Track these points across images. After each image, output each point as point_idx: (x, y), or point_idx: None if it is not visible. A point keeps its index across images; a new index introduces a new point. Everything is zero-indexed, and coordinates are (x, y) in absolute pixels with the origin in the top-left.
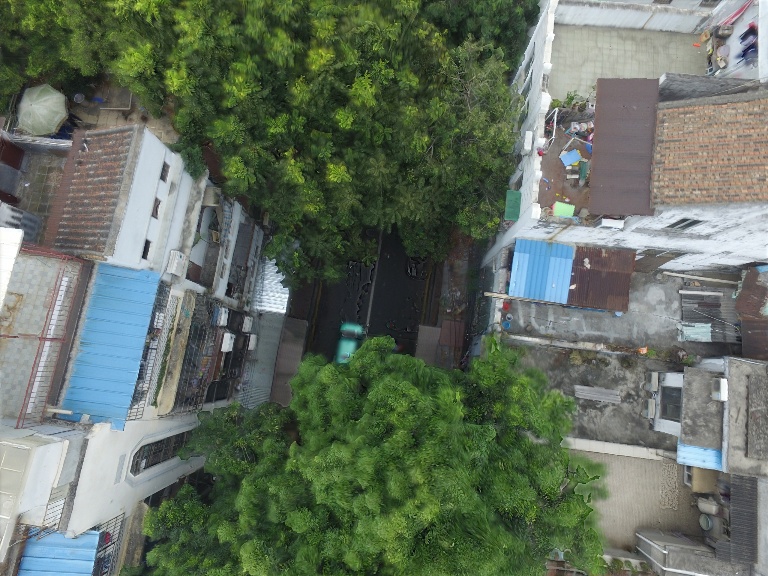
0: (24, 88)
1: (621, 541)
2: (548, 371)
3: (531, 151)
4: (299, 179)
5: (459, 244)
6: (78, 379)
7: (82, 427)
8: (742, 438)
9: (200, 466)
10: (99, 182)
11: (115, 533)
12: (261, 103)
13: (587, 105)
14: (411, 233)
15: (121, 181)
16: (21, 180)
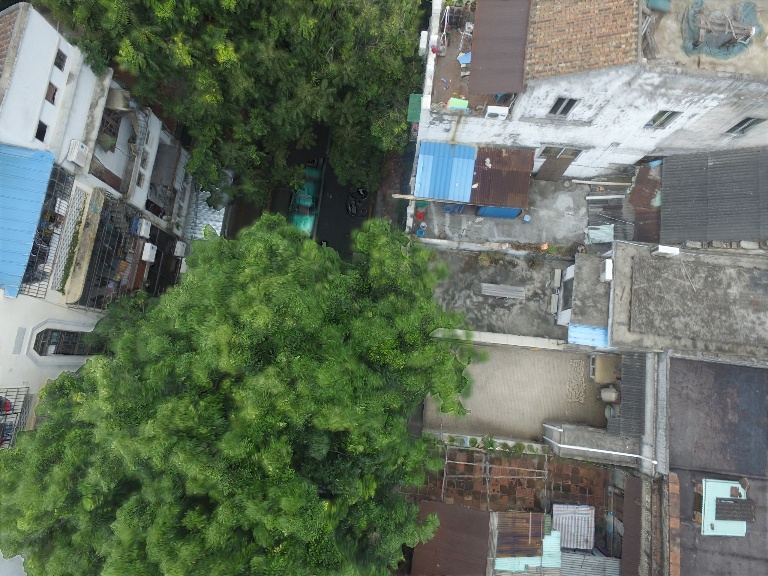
0: None
1: (529, 432)
2: (459, 274)
3: (427, 50)
4: (188, 62)
5: (391, 175)
6: None
7: None
8: (626, 314)
9: None
10: None
11: (17, 404)
12: None
13: None
14: (340, 160)
15: None
16: None
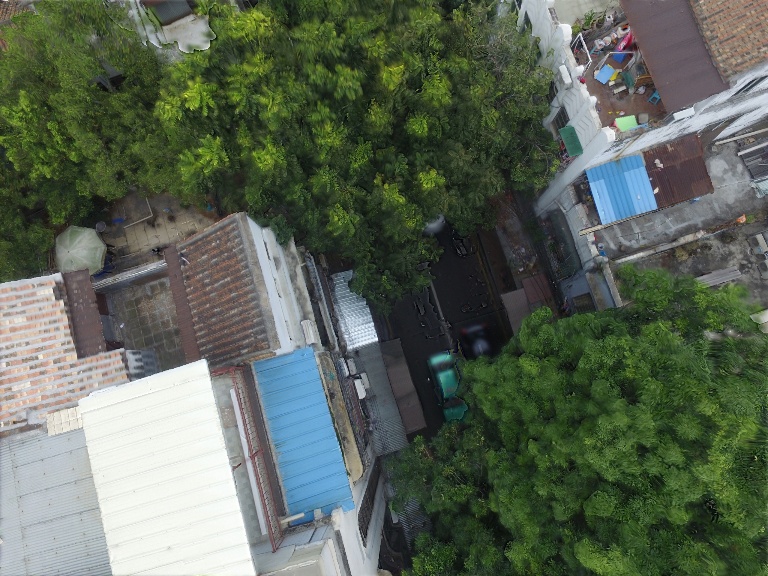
0: (54, 239)
1: None
2: None
3: (571, 83)
4: (399, 199)
5: (501, 205)
6: (290, 480)
7: (322, 522)
8: None
9: (383, 516)
10: (221, 286)
11: None
12: (346, 142)
13: (605, 19)
14: None
15: (248, 274)
16: (114, 324)
